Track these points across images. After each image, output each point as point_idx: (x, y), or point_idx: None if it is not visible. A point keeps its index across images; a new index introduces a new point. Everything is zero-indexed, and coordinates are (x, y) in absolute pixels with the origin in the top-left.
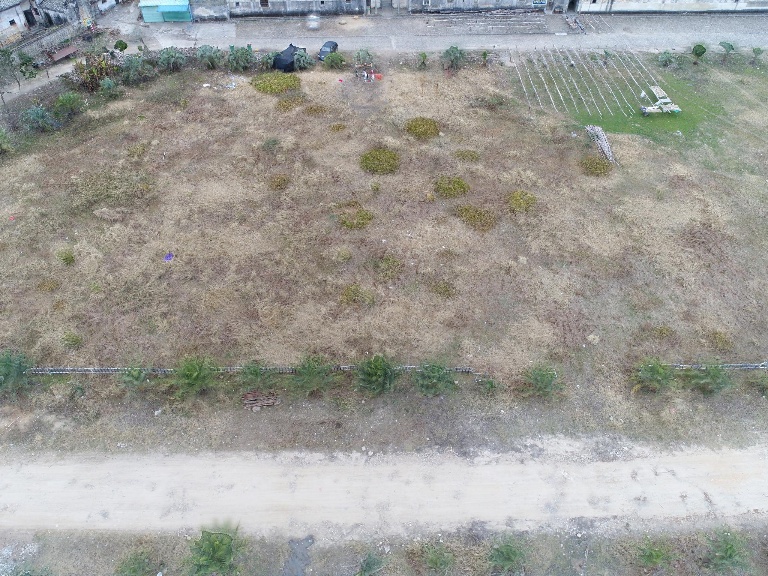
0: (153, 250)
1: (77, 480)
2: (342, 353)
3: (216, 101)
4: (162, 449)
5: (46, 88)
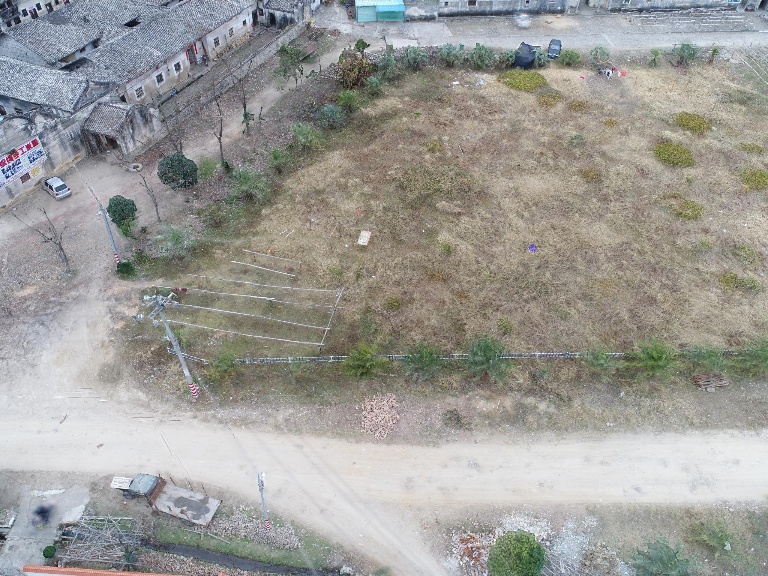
0: (516, 241)
1: (589, 458)
2: (757, 337)
3: (476, 98)
4: (649, 428)
5: (306, 87)
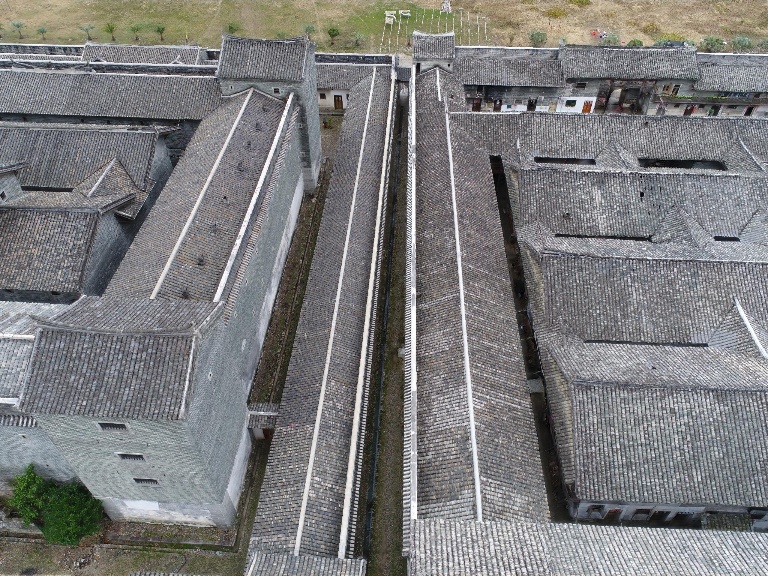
0: None
1: None
2: None
3: None
4: None
5: None
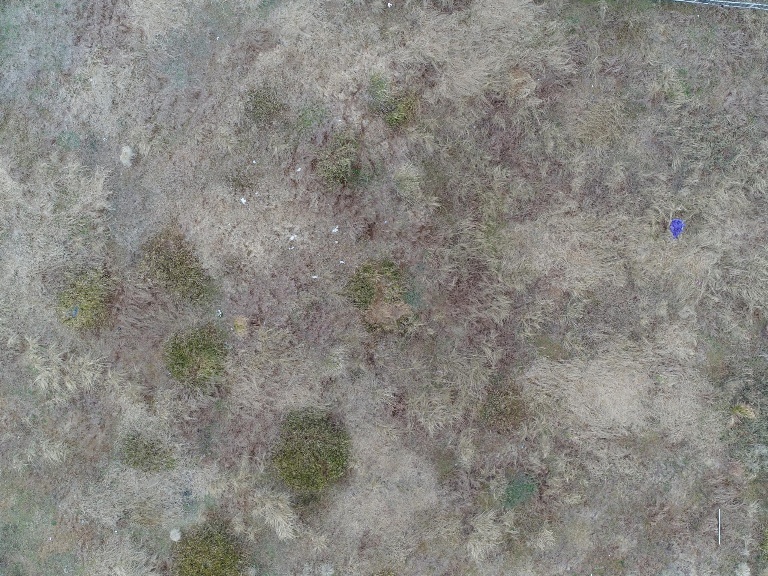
0: (704, 240)
1: None
2: (423, 6)
3: None
4: None
5: None
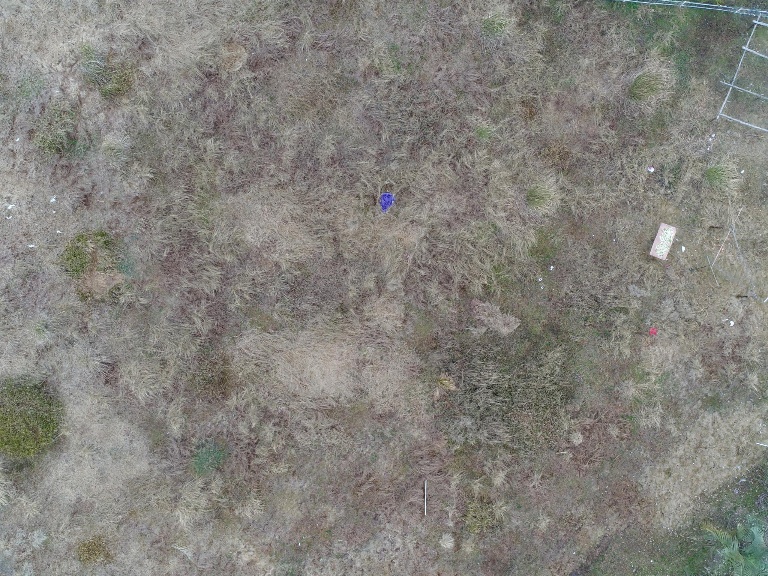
0: (411, 214)
1: None
2: None
3: None
4: None
5: None
